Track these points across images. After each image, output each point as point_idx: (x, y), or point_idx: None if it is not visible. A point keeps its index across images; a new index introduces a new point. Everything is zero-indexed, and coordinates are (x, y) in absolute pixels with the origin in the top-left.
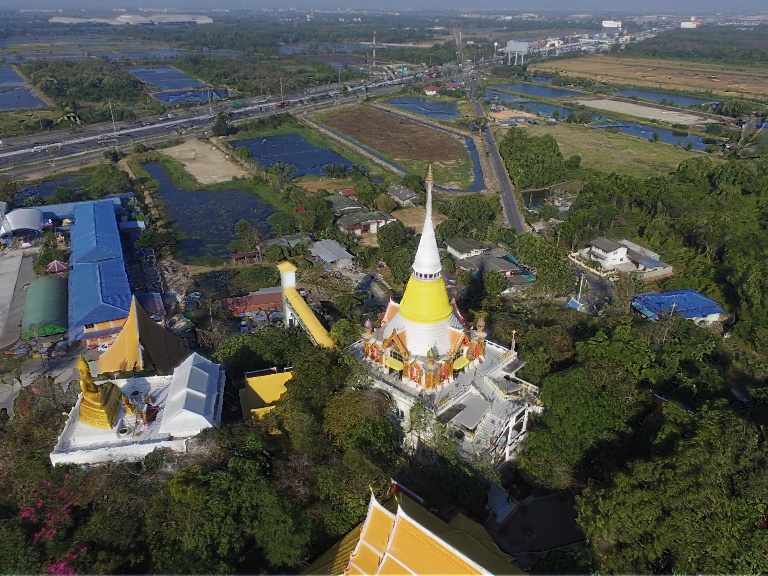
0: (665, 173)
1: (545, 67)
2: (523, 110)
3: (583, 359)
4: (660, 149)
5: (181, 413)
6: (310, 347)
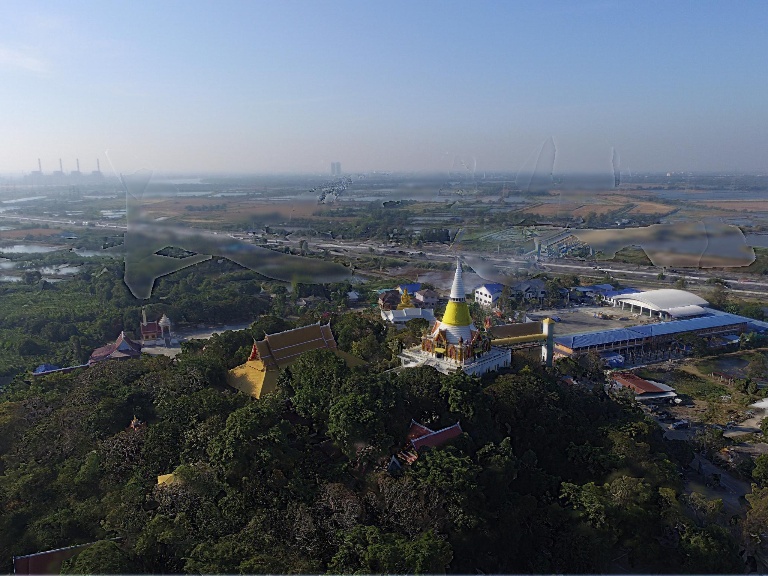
0: None
1: None
2: None
3: None
4: None
5: None
6: None
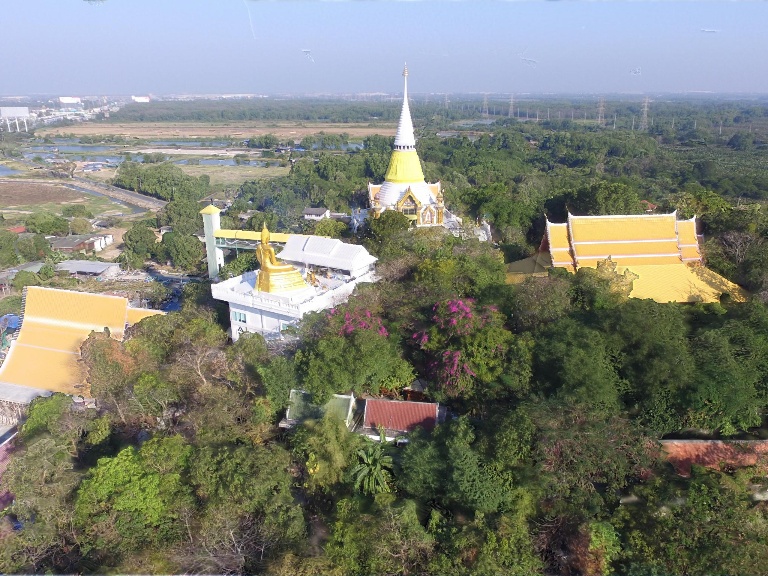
0: None
1: (57, 130)
2: (87, 160)
3: (477, 202)
4: (249, 168)
5: (360, 251)
6: None
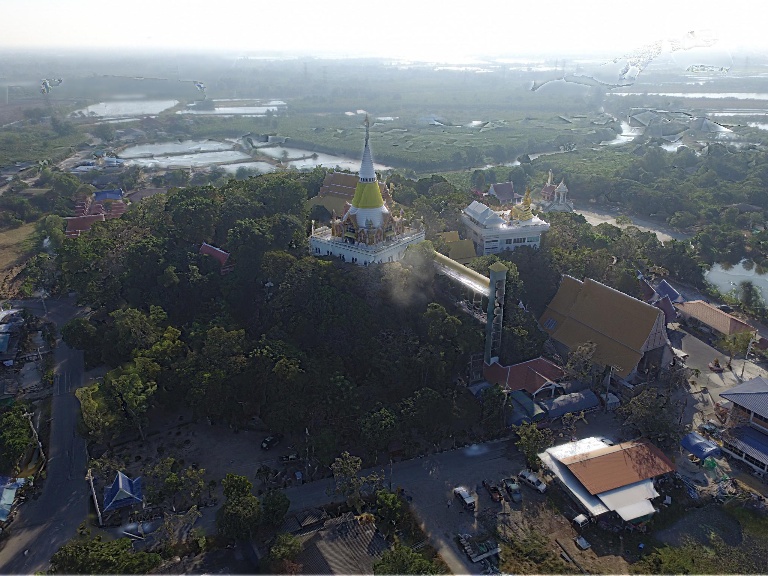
0: None
1: None
2: None
3: None
4: None
5: None
6: (443, 242)
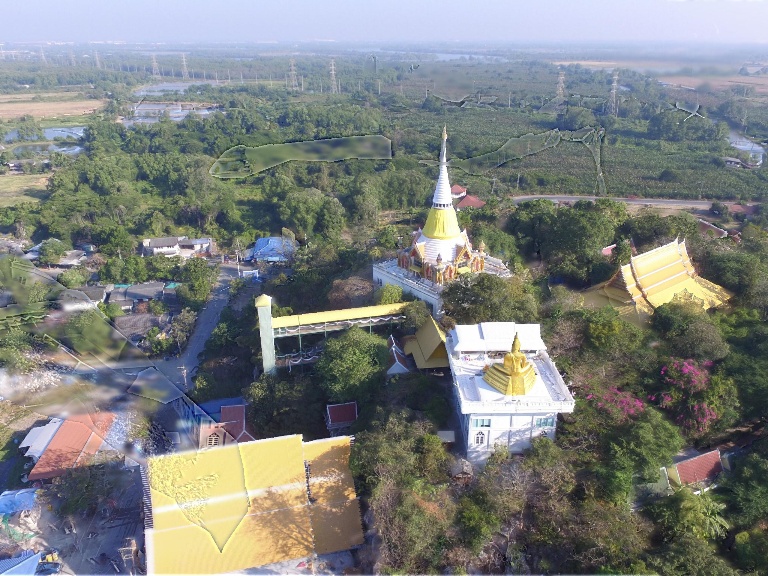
0: (23, 196)
1: None
2: None
3: None
4: None
5: None
6: None
